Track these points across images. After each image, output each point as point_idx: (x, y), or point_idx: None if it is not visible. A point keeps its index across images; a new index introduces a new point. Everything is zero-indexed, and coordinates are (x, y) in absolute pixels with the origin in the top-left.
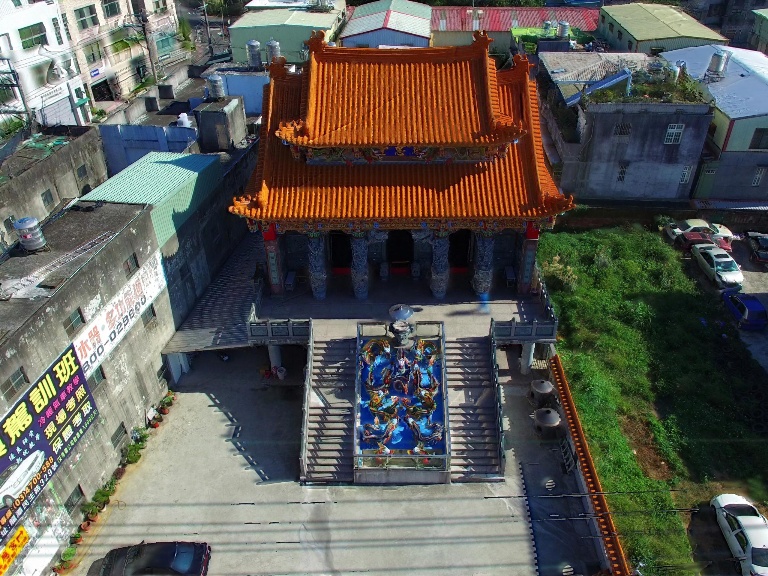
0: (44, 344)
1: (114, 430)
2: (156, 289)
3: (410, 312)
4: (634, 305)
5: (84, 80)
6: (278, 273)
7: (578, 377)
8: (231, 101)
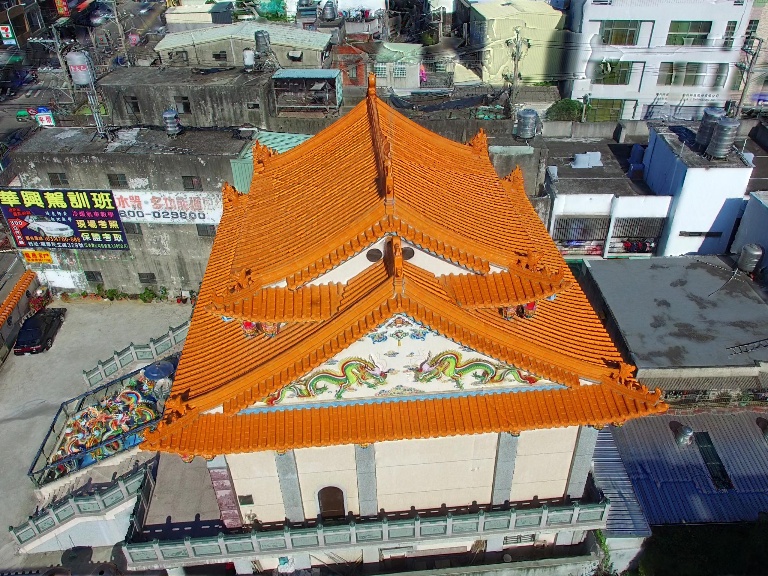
0: (87, 174)
1: (144, 271)
2: None
3: (154, 376)
4: None
5: None
6: None
7: None
8: (523, 146)
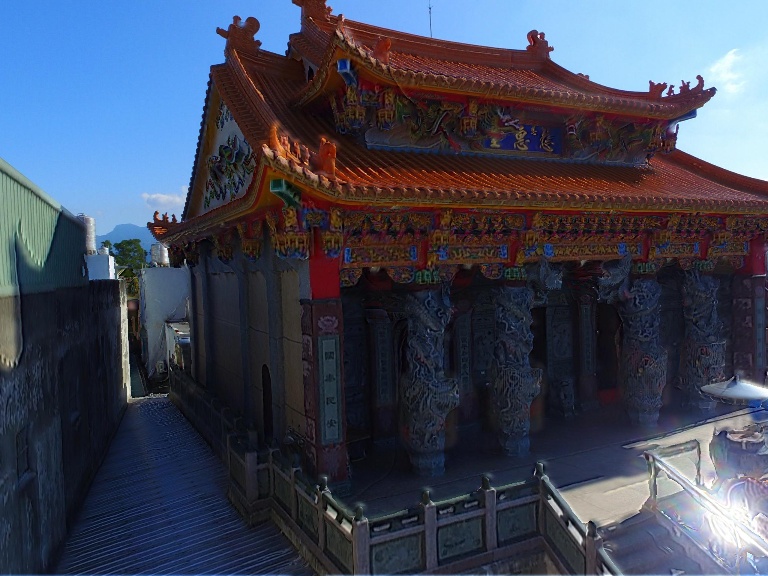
0: None
1: None
2: None
3: None
4: None
5: None
6: (339, 406)
7: None
8: None
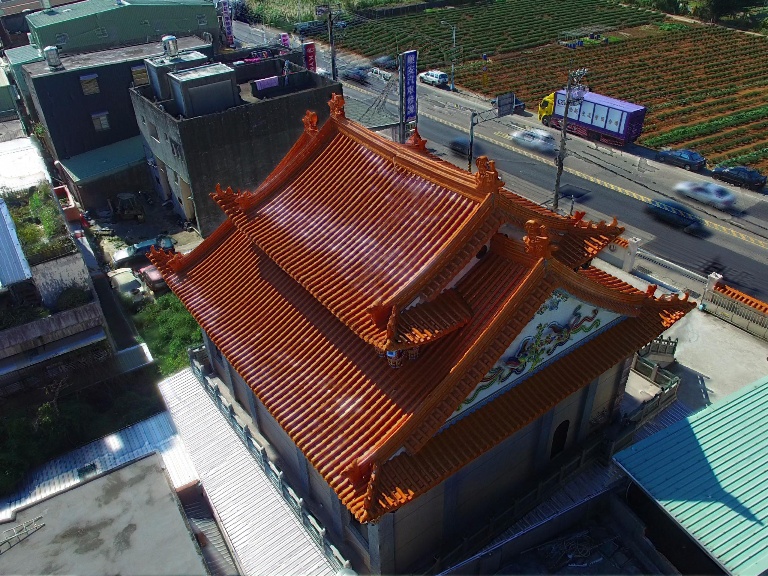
0: None
1: None
2: None
3: None
4: None
5: None
6: None
7: None
8: None
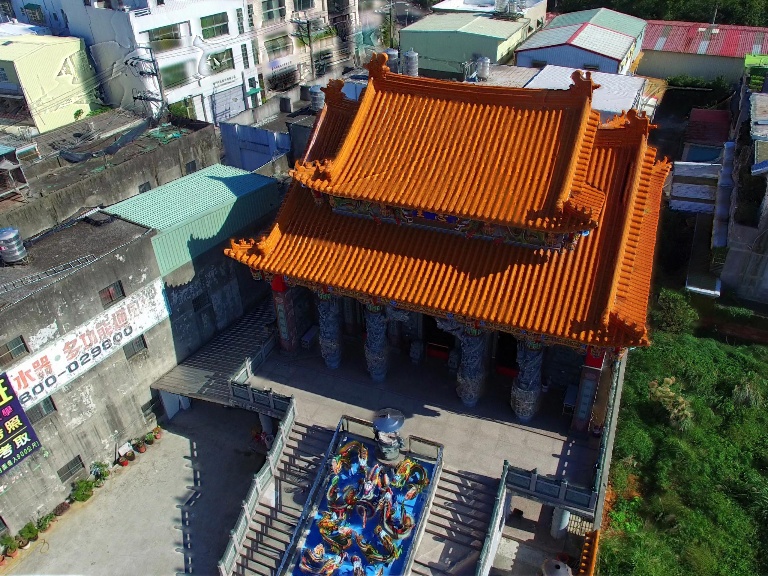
0: None
1: (64, 463)
2: (151, 319)
3: (398, 424)
4: (759, 481)
5: (260, 70)
6: (287, 328)
7: (624, 569)
8: None
